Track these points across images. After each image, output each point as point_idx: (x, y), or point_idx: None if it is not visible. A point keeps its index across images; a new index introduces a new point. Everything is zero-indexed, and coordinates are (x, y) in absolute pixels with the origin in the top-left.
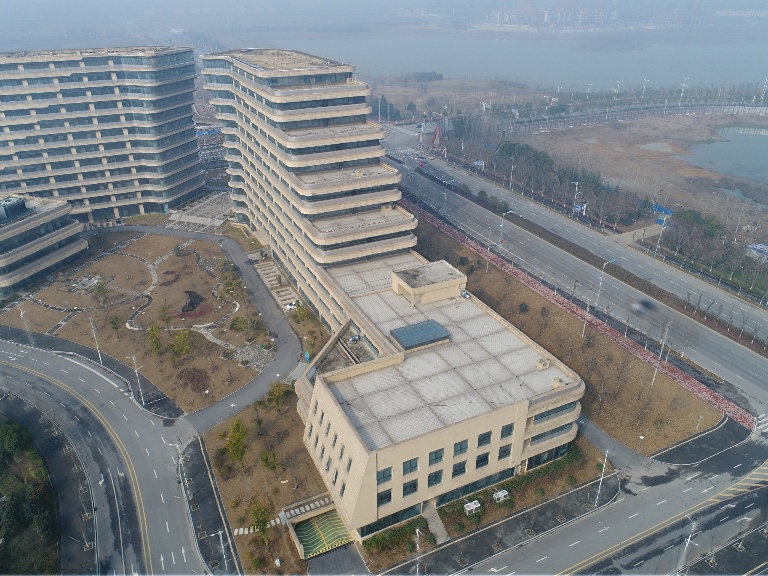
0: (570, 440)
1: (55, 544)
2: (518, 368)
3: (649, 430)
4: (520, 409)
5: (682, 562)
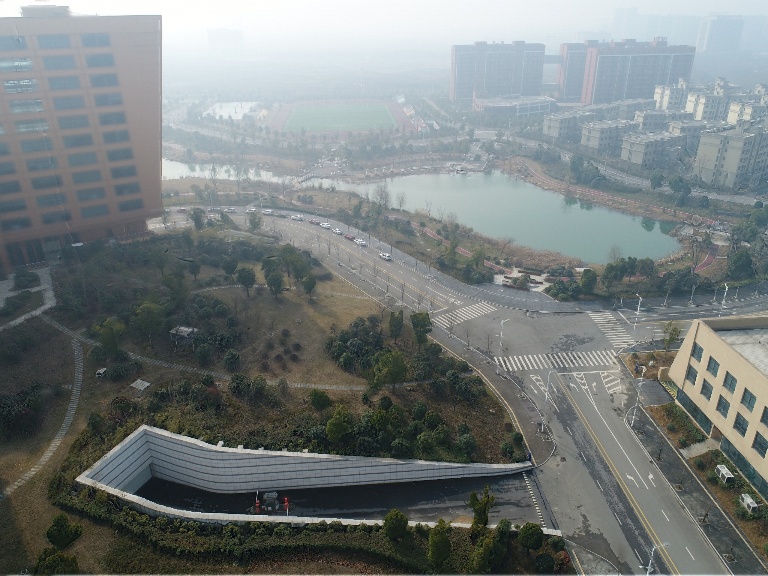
0: None
1: (665, 296)
2: None
3: None
4: None
5: None
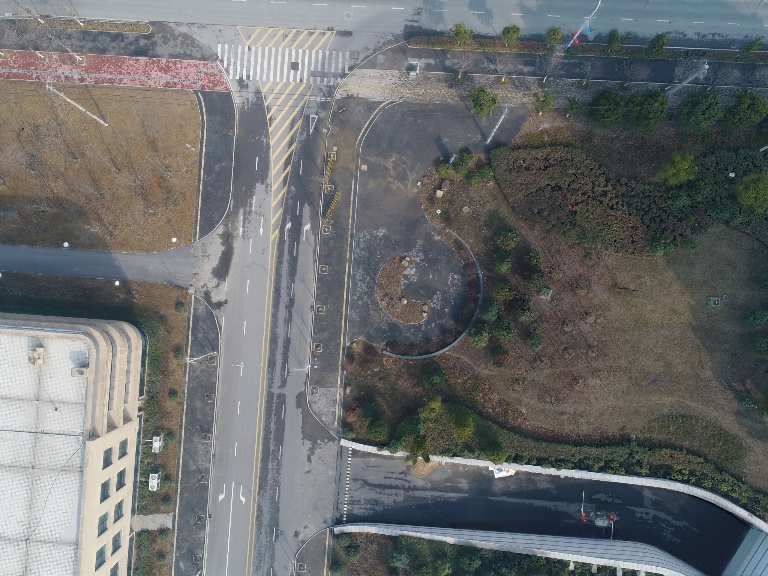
0: (141, 345)
1: None
2: (23, 386)
3: (166, 206)
4: (95, 452)
5: (306, 333)
